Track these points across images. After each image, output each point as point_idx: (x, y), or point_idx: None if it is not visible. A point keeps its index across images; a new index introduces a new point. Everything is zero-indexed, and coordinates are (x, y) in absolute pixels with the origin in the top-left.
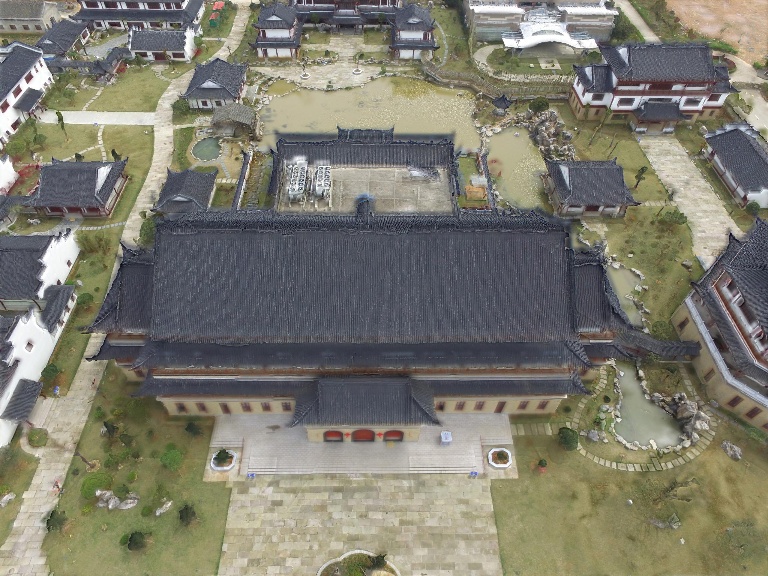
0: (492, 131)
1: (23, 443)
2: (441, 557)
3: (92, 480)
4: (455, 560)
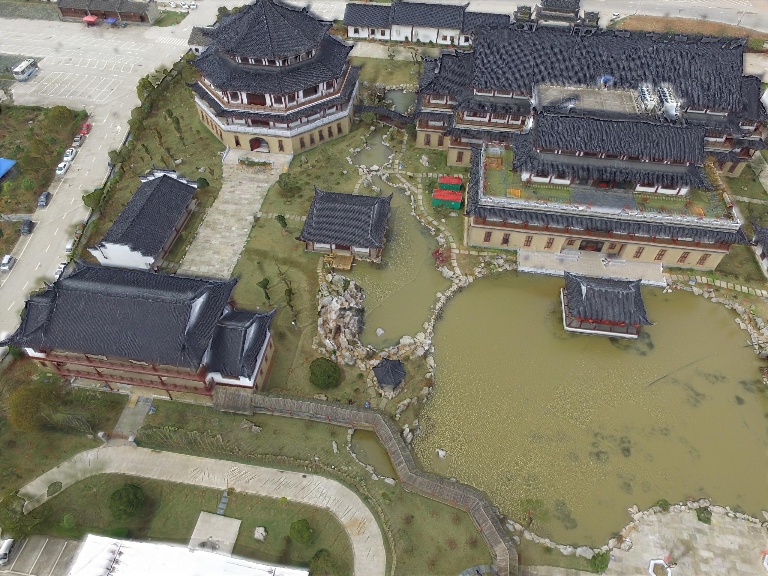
0: (415, 340)
1: None
2: None
3: None
4: None
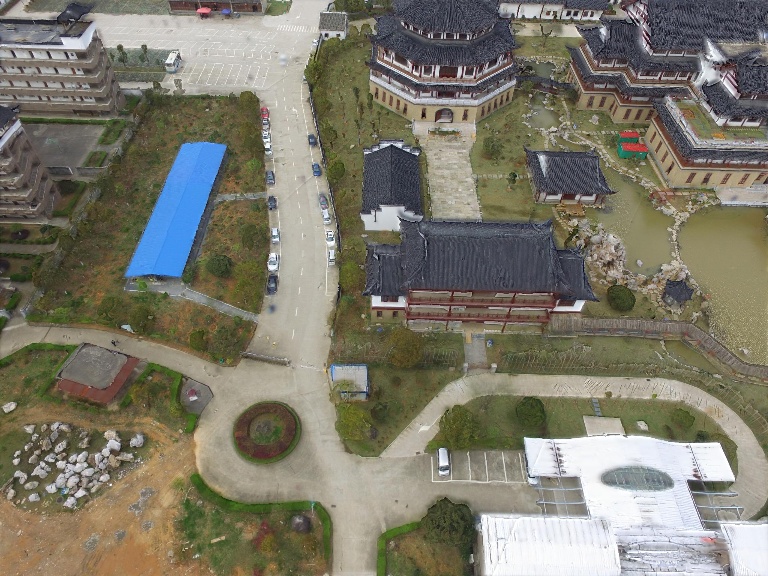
0: (673, 266)
1: None
2: None
3: None
4: None
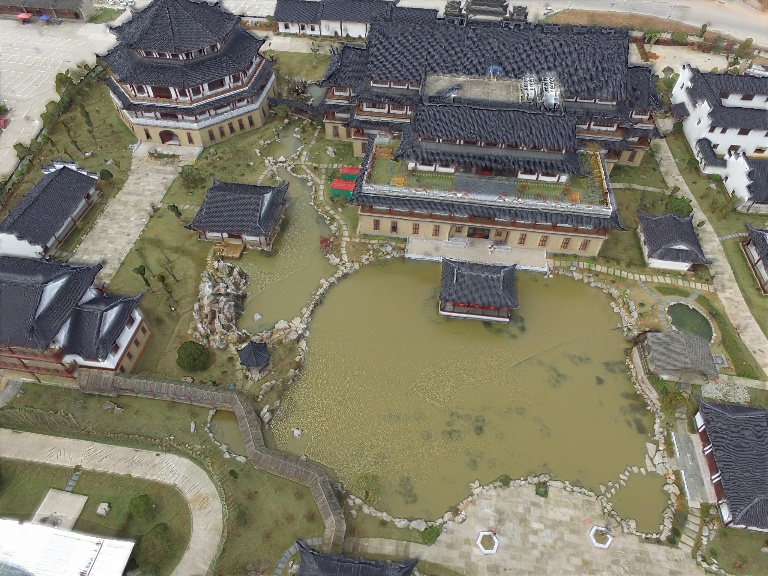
0: (290, 324)
1: (668, 114)
2: None
3: None
4: None
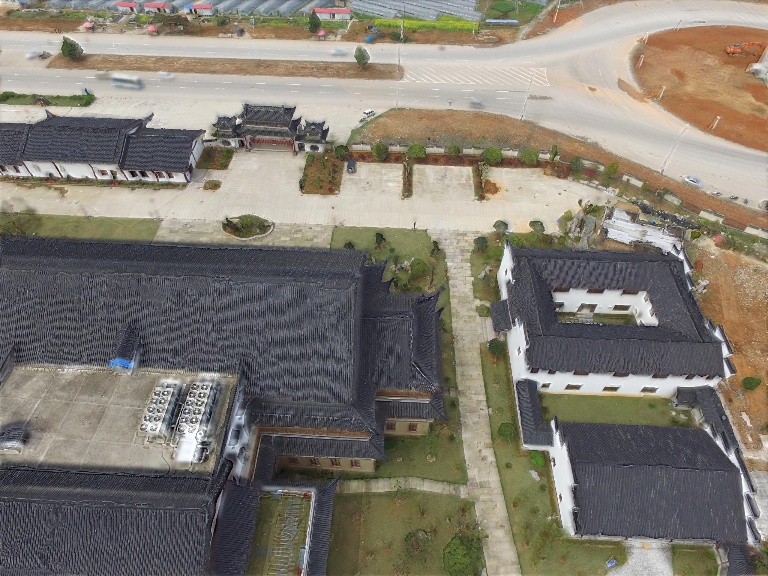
0: None
1: None
2: (193, 236)
3: (418, 262)
4: (185, 234)
